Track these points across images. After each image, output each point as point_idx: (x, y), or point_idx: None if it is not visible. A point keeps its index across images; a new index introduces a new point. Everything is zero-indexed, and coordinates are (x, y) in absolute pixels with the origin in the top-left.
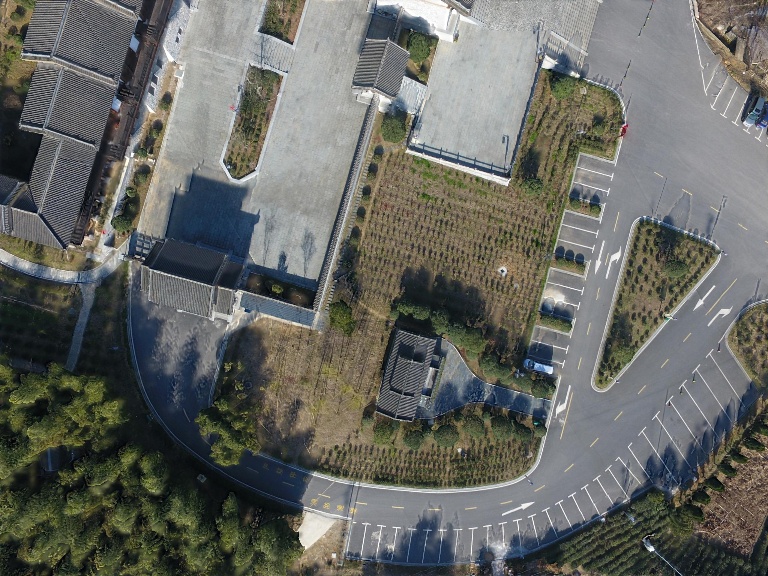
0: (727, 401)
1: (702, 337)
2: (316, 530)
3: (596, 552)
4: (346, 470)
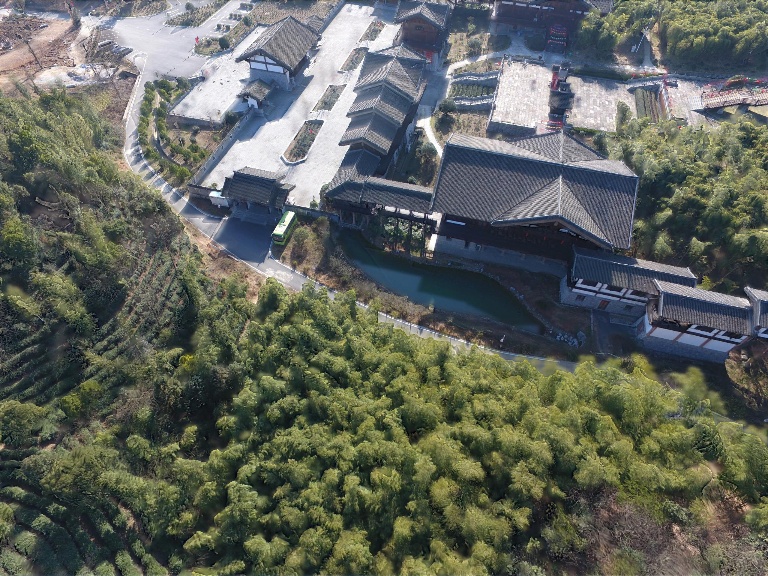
0: None
1: None
2: None
3: None
4: None
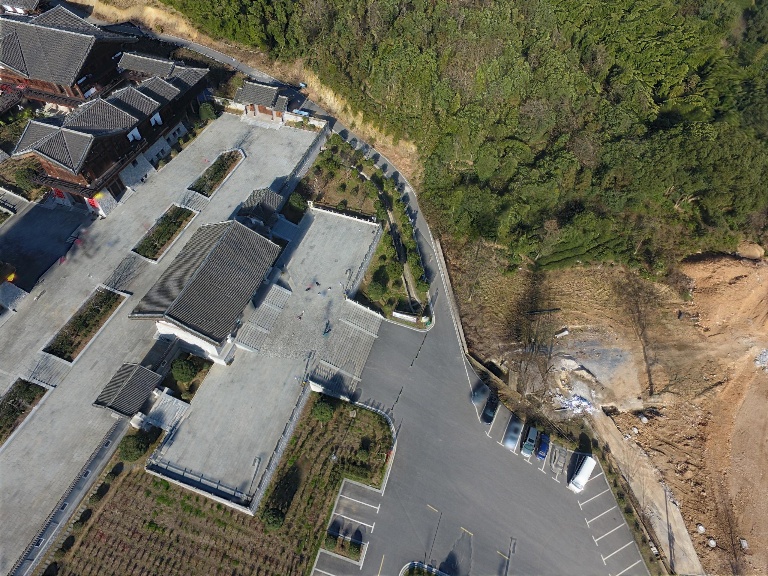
0: None
1: None
2: None
3: None
4: None
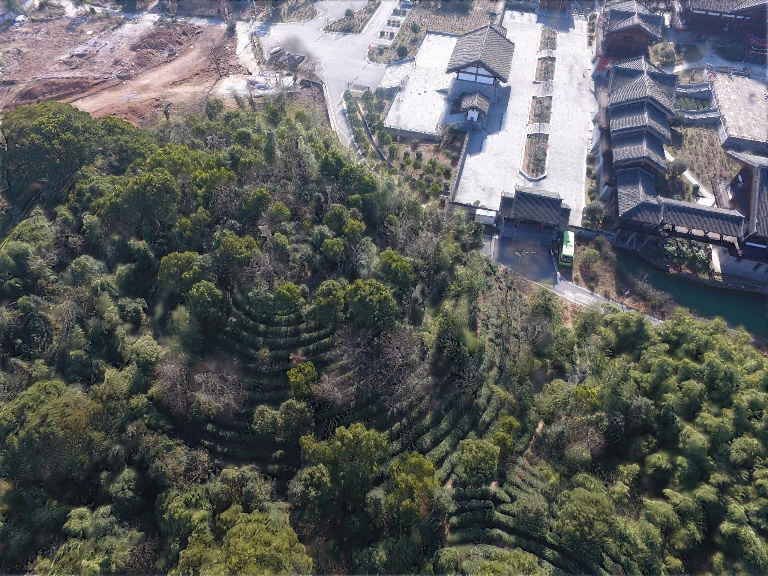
0: (324, 1)
1: (333, 12)
2: None
3: None
4: None
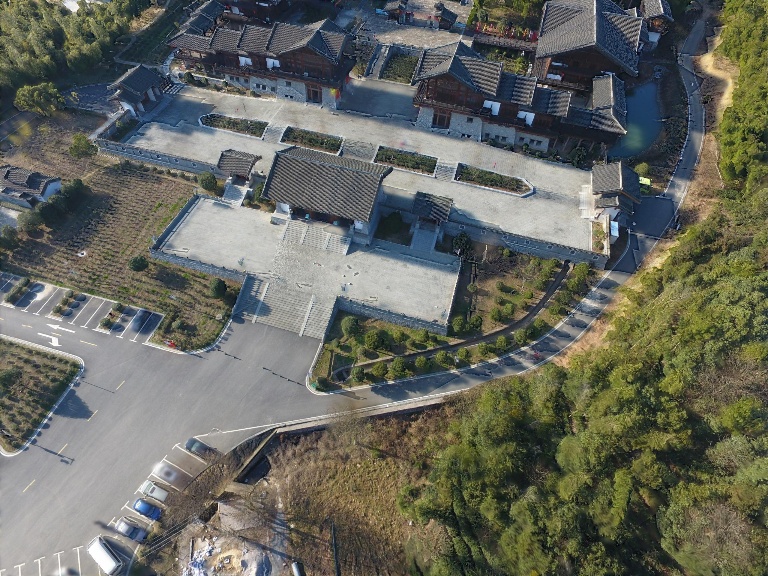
0: None
1: None
2: None
3: None
4: None
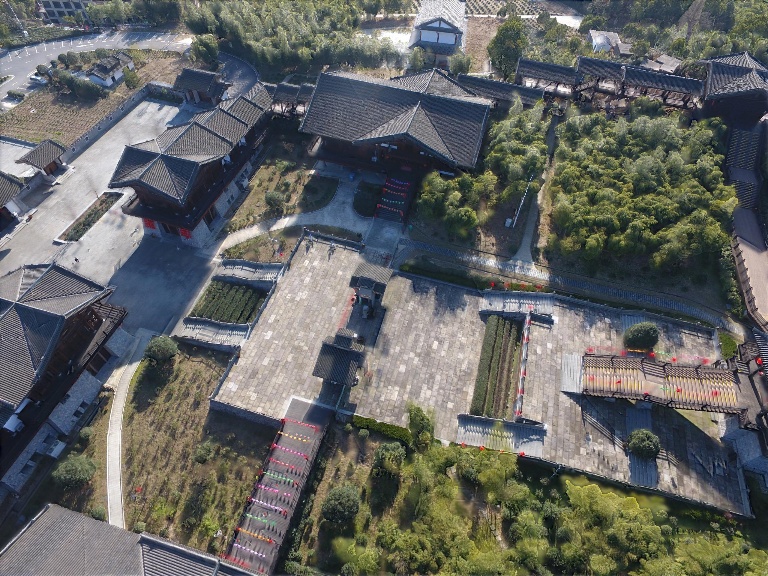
0: None
1: None
2: (188, 40)
3: (54, 33)
4: (164, 53)
